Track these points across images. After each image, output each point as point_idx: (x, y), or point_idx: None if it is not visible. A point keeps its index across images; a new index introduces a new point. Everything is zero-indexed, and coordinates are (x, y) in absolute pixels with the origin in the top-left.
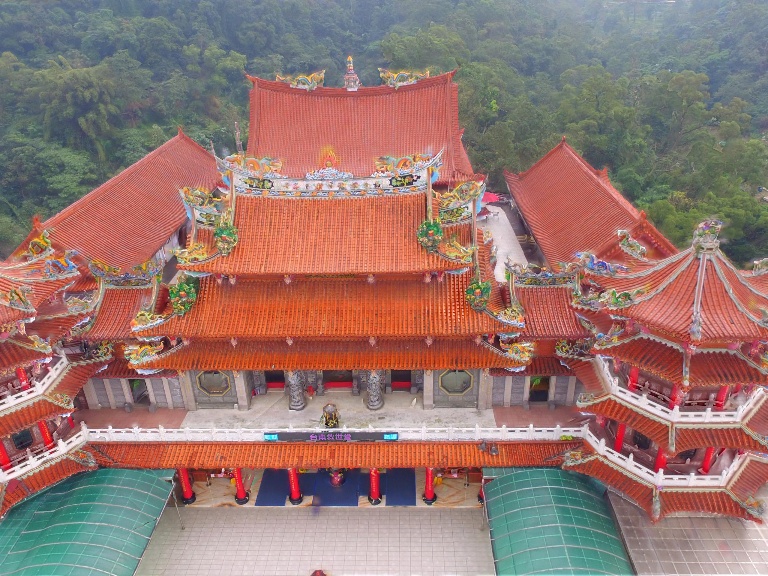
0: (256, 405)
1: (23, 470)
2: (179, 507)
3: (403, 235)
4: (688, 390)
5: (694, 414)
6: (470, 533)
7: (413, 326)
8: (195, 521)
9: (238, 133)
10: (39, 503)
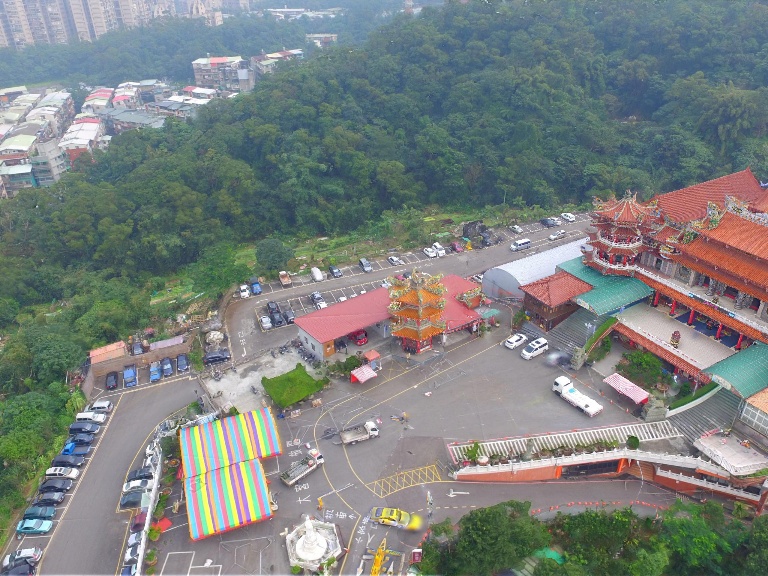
0: (695, 287)
1: (614, 267)
2: (650, 306)
3: None
4: None
5: None
6: None
7: (762, 281)
8: (653, 311)
9: None
10: (614, 278)
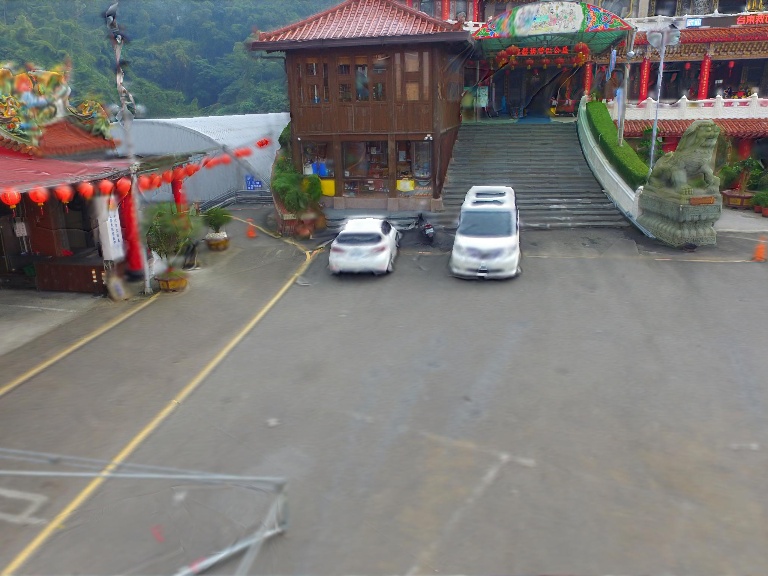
0: None
1: None
2: None
3: None
4: None
5: None
6: None
7: None
8: None
9: None
10: None
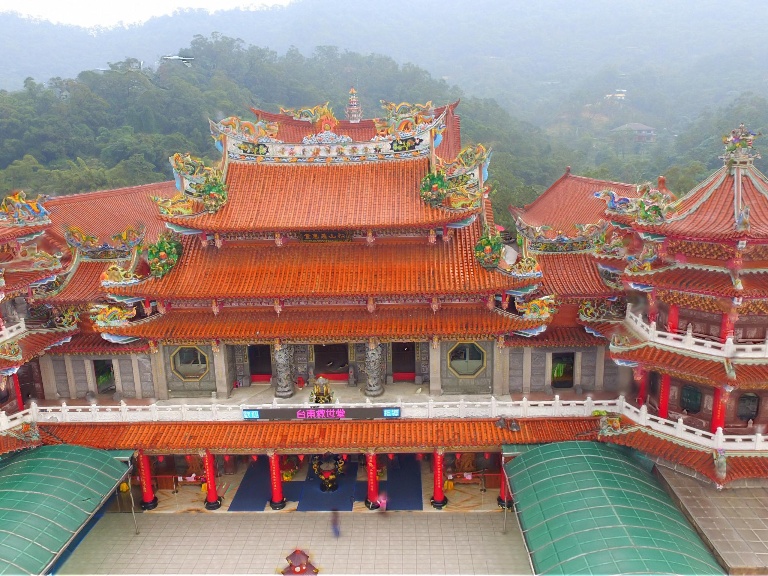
0: (237, 394)
1: None
2: (136, 513)
3: (405, 194)
4: (743, 293)
5: (751, 347)
6: (490, 536)
7: (417, 284)
8: (153, 526)
9: None
10: None
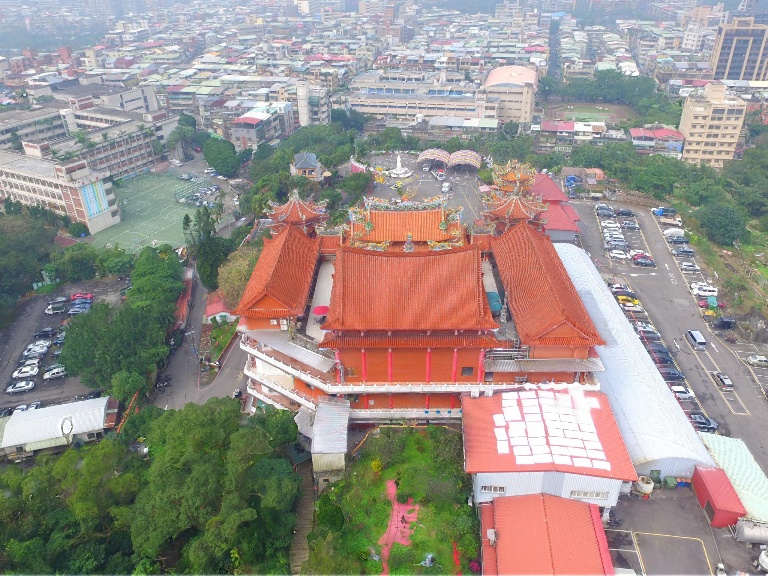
0: None
1: None
2: None
3: None
4: None
5: None
6: None
7: None
8: None
9: None
10: None
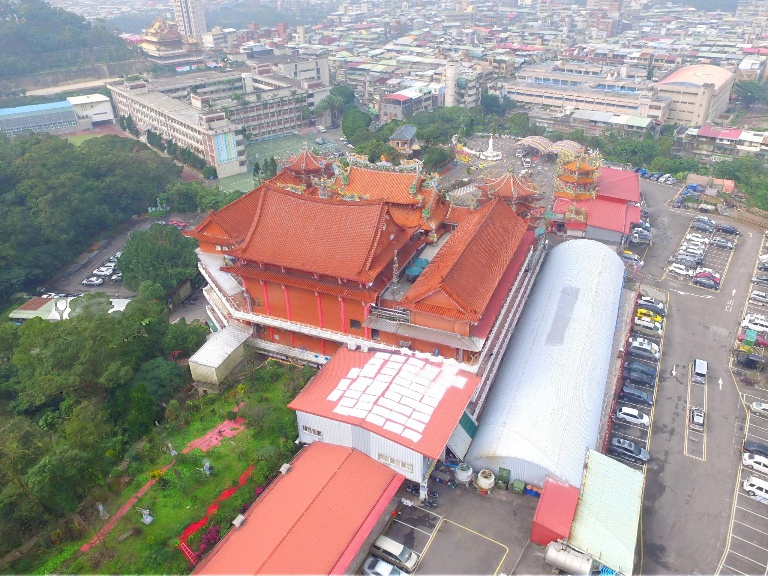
0: None
1: None
2: None
3: None
4: None
5: None
6: None
7: None
8: None
9: (396, 258)
10: None
